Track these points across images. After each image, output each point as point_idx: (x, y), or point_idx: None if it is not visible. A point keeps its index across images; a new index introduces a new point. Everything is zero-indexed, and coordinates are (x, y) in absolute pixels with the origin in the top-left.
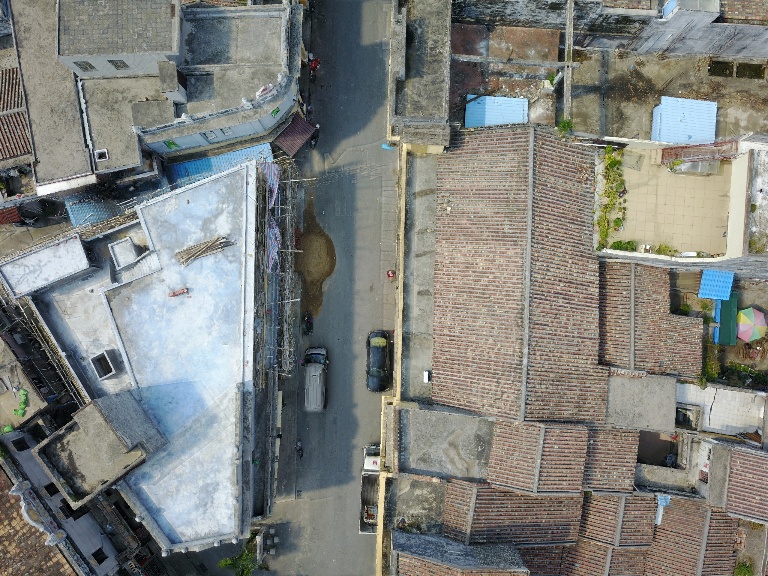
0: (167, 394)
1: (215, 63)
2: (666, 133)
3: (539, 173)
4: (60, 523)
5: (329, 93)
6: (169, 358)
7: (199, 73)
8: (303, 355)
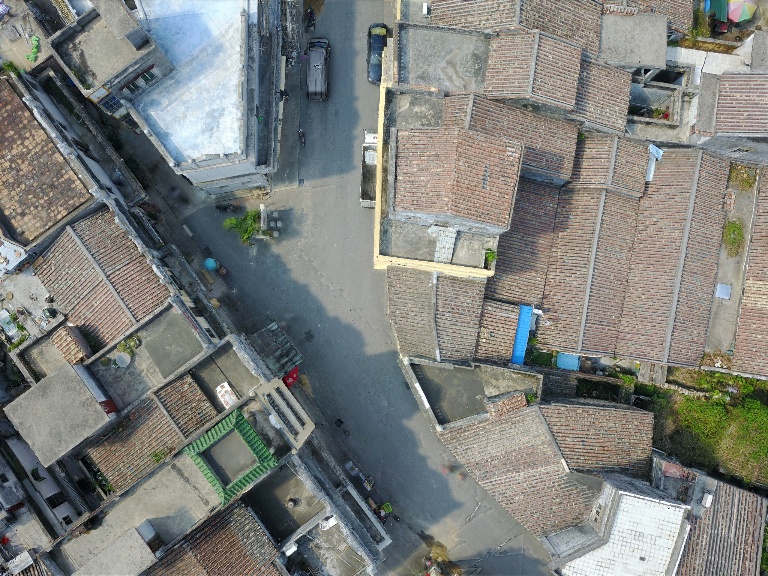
0: (175, 25)
1: None
2: None
3: None
4: (71, 144)
5: None
6: None
7: None
8: None
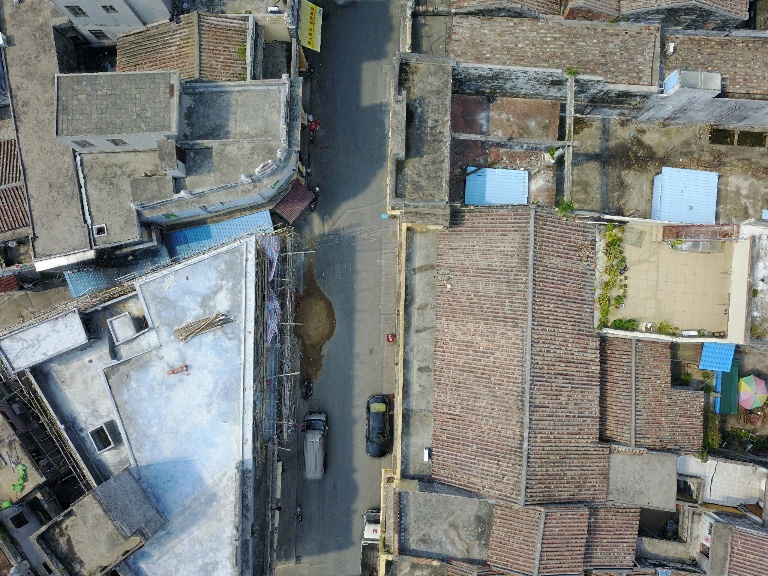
0: (166, 472)
1: (214, 137)
2: (667, 204)
3: (540, 254)
4: None
5: (329, 155)
6: (168, 436)
7: (198, 147)
8: (303, 419)
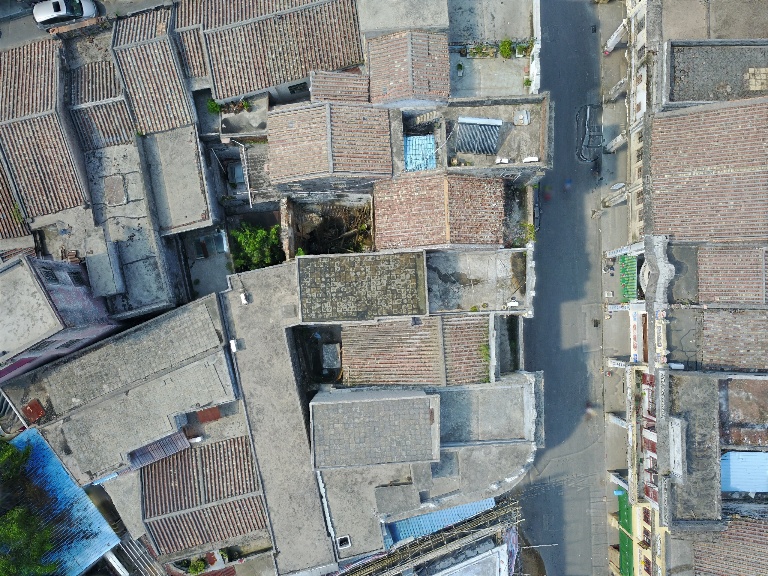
0: None
1: (456, 438)
2: None
3: None
4: None
5: None
6: None
7: None
8: None
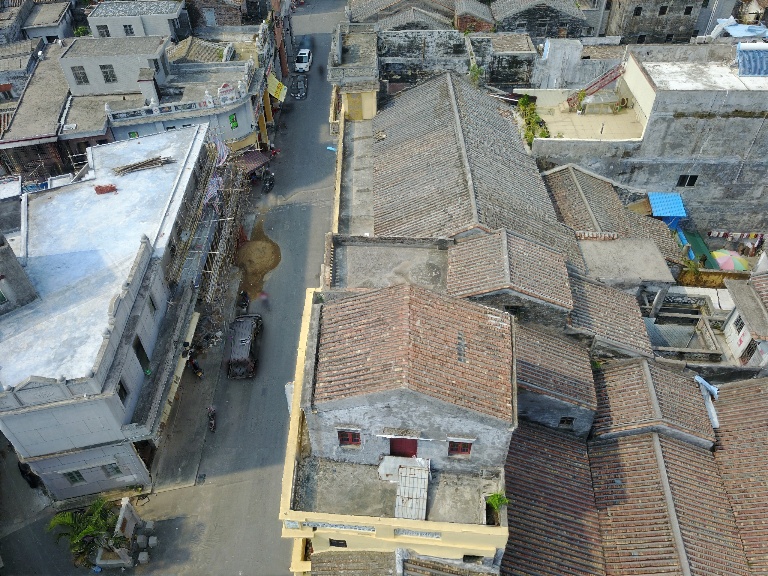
0: (59, 261)
1: None
2: None
3: (459, 94)
4: None
5: (286, 165)
6: (74, 235)
7: (173, 92)
8: None
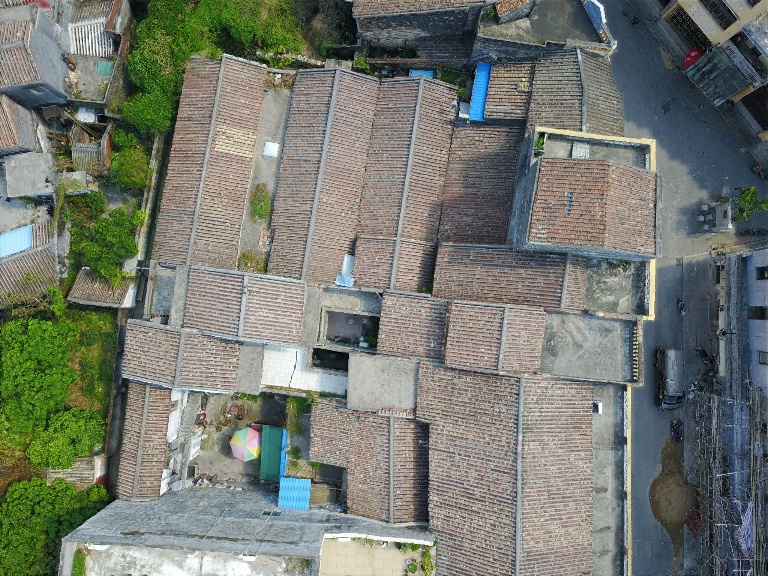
0: None
1: None
2: None
3: None
4: None
5: None
6: None
7: None
8: None
